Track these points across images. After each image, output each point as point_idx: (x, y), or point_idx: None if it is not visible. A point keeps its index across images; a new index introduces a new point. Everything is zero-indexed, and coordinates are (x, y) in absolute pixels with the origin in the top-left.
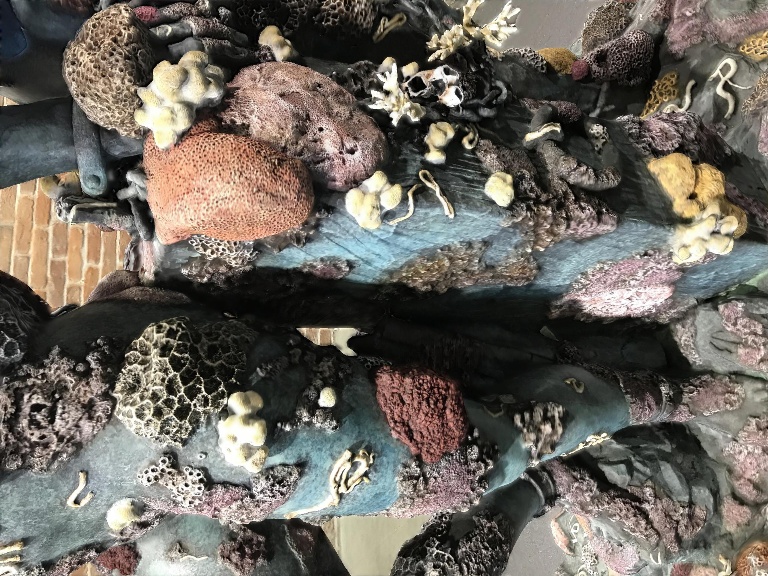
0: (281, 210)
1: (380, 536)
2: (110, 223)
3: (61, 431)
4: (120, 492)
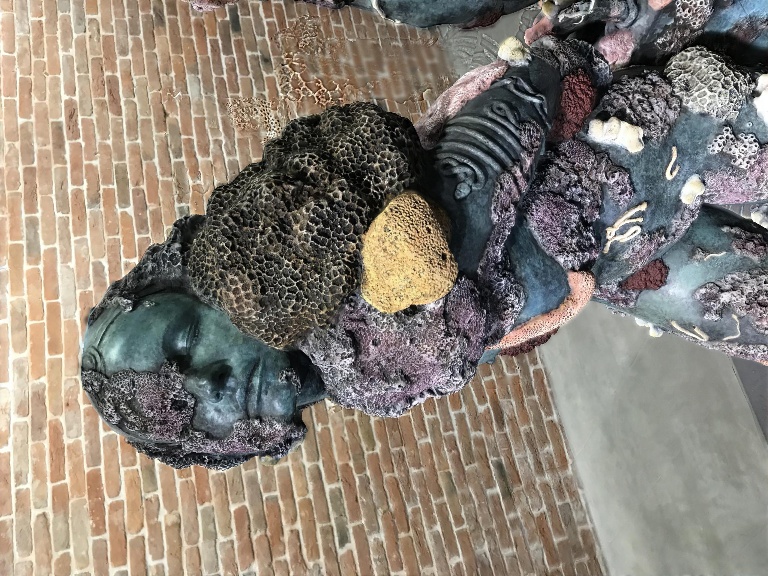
0: None
1: (641, 492)
2: (613, 8)
3: (660, 114)
4: (693, 167)
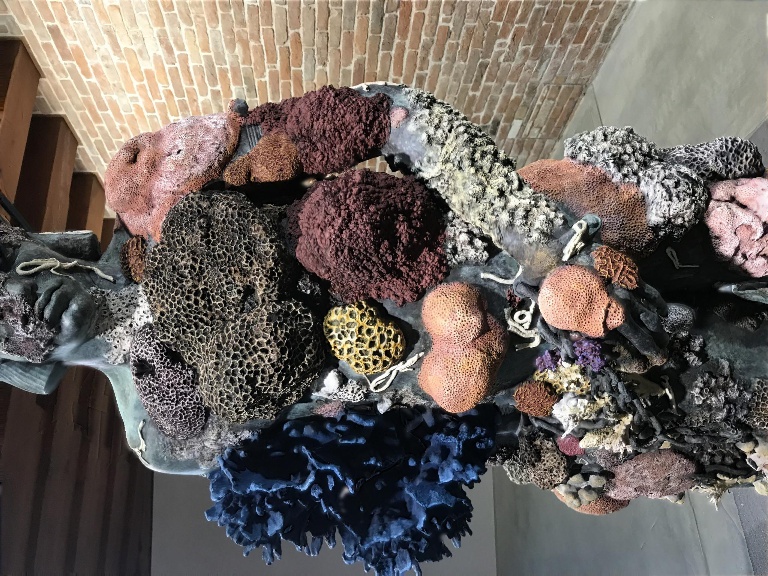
0: None
1: (697, 2)
2: None
3: None
4: None
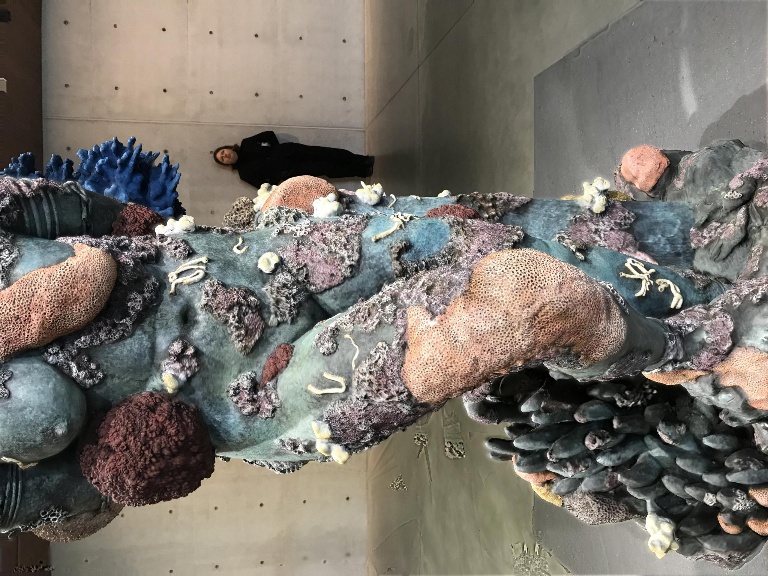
0: (321, 183)
1: None
2: None
3: None
4: (263, 247)
